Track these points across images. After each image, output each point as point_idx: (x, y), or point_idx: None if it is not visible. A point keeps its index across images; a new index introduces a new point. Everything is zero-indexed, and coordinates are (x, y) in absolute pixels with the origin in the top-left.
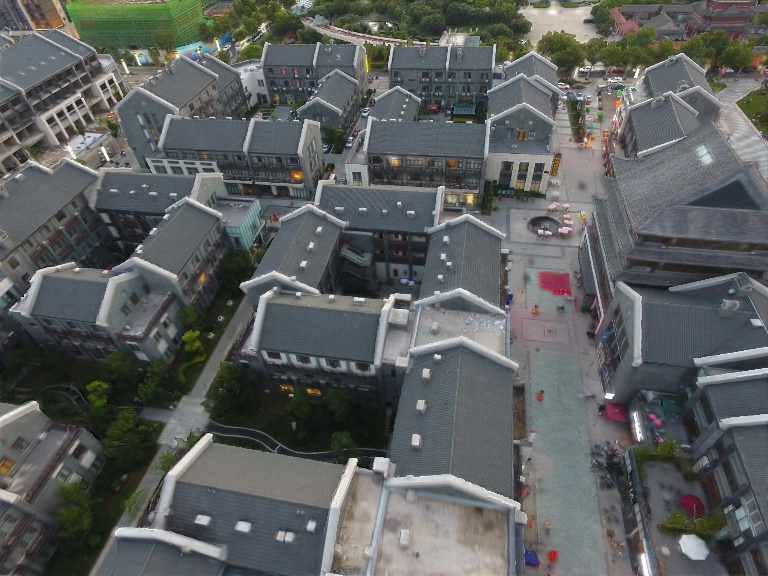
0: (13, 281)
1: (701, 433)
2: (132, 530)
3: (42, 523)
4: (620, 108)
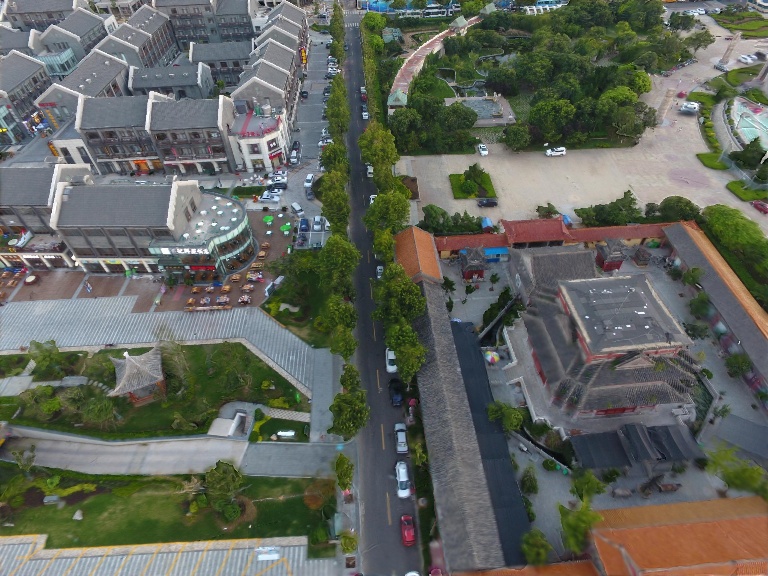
0: (12, 25)
1: None
2: None
3: None
4: None
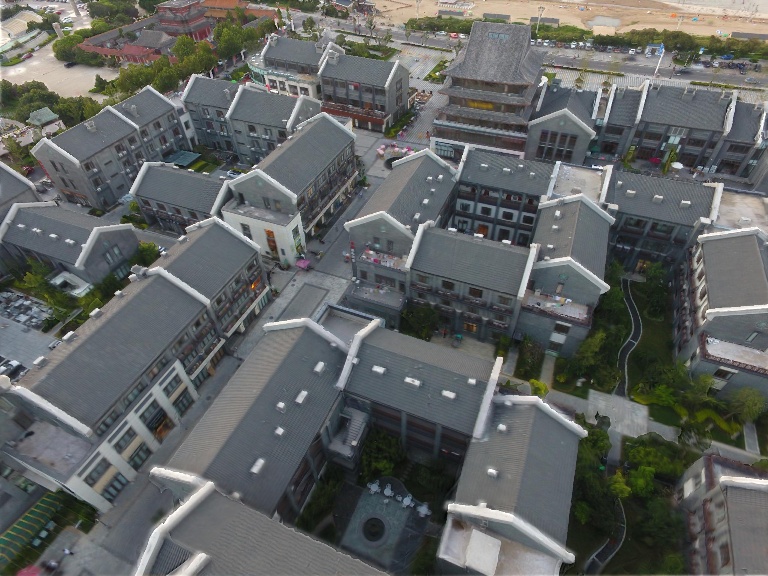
0: None
1: (619, 142)
2: None
3: None
4: (289, 85)
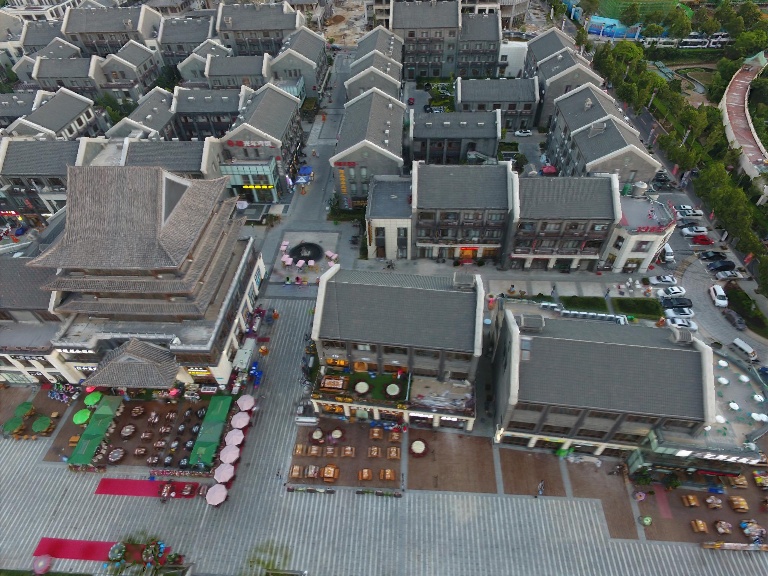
0: (222, 43)
1: None
2: (52, 92)
3: (100, 98)
4: None
